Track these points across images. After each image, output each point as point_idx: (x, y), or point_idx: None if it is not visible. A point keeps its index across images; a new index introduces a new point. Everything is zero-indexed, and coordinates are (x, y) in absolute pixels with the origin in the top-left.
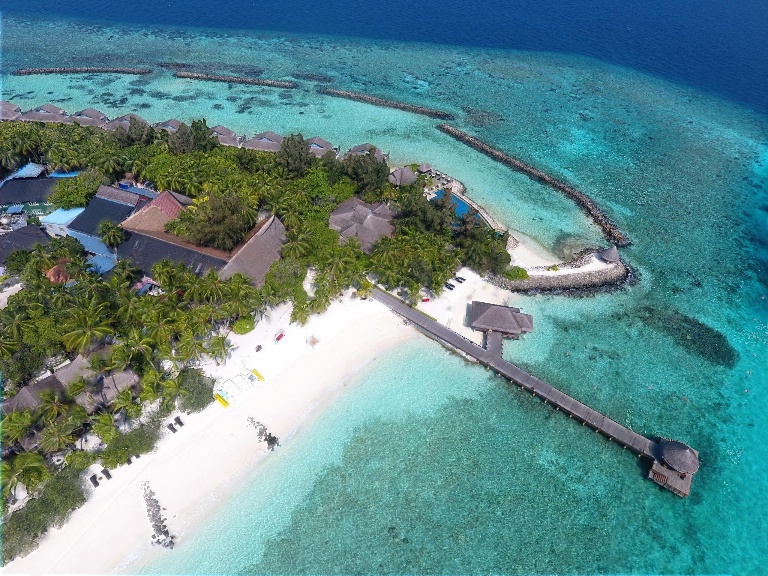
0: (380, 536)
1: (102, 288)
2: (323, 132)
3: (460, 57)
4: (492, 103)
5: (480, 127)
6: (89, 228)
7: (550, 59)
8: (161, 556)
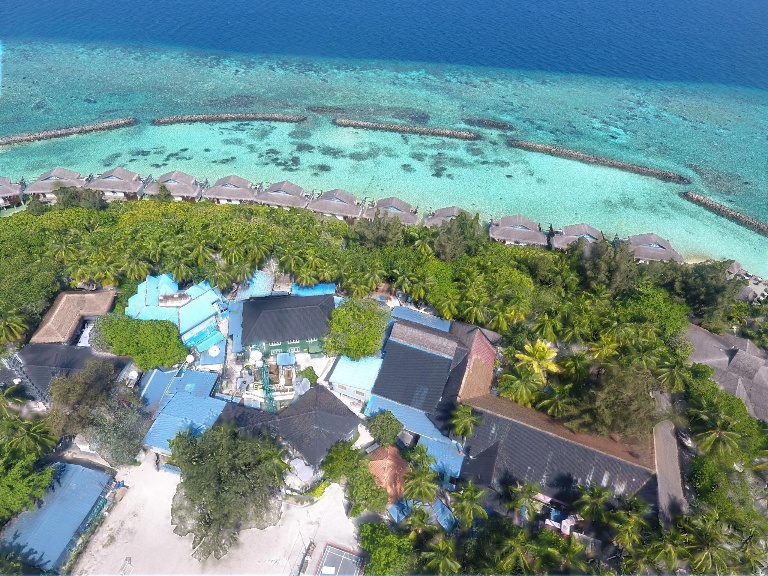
0: None
1: (497, 526)
2: (552, 205)
3: (632, 93)
4: (716, 158)
5: (730, 194)
6: (404, 395)
7: (733, 95)
8: None
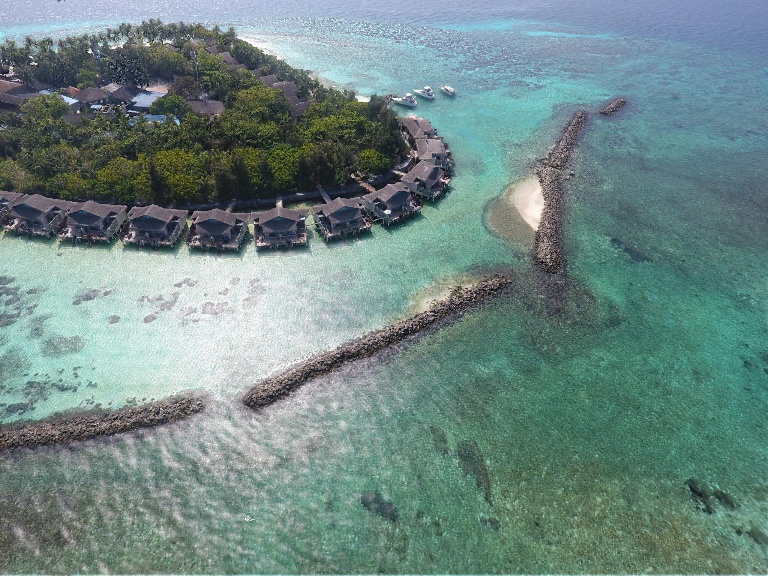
0: None
1: (42, 73)
2: None
3: None
4: None
5: None
6: None
7: None
8: None
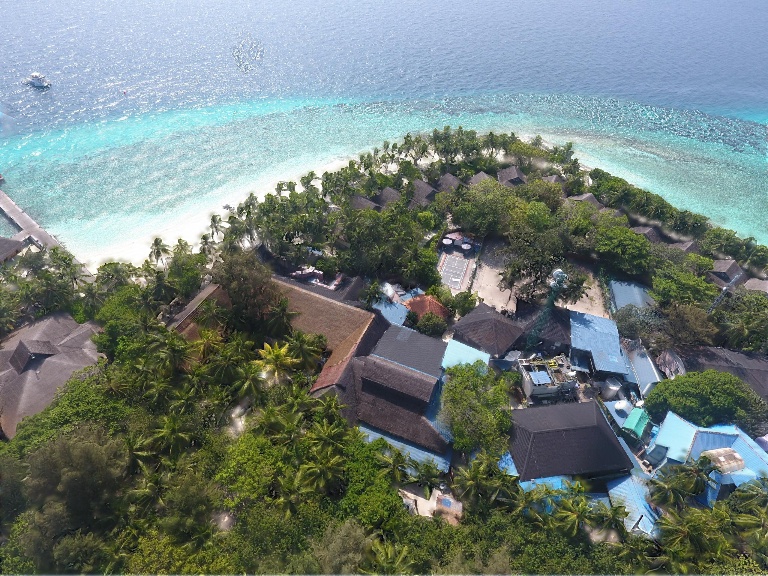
0: (179, 178)
1: (360, 260)
2: None
3: None
4: None
5: None
6: (419, 337)
7: None
8: (285, 180)
